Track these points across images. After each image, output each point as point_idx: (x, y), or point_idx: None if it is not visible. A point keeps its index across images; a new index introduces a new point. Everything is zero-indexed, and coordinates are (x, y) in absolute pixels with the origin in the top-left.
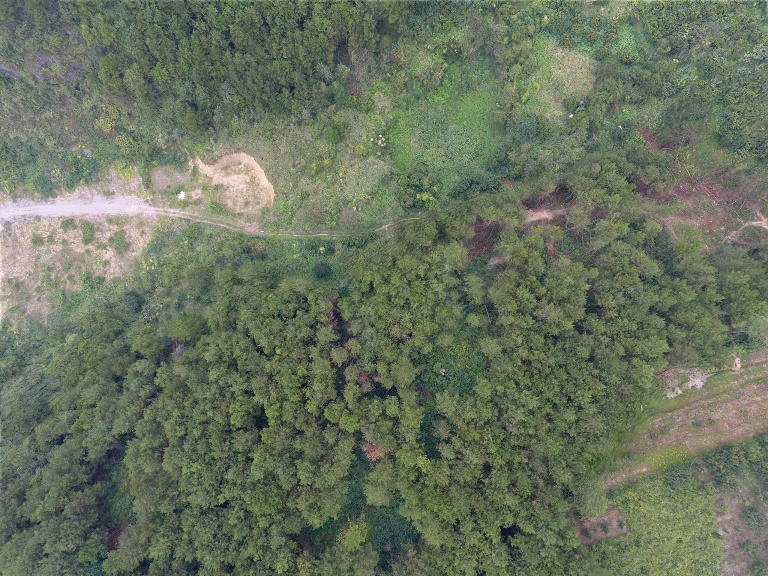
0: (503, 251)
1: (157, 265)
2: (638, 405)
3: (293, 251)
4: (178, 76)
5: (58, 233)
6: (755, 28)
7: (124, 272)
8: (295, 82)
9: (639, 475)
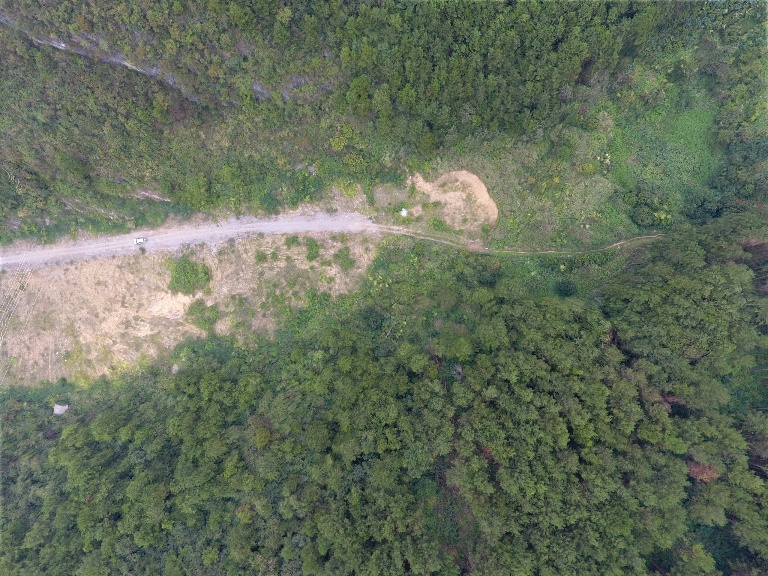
0: None
1: (390, 282)
2: None
3: (528, 269)
4: (425, 97)
5: (282, 250)
6: None
7: (350, 288)
8: (539, 103)
9: None
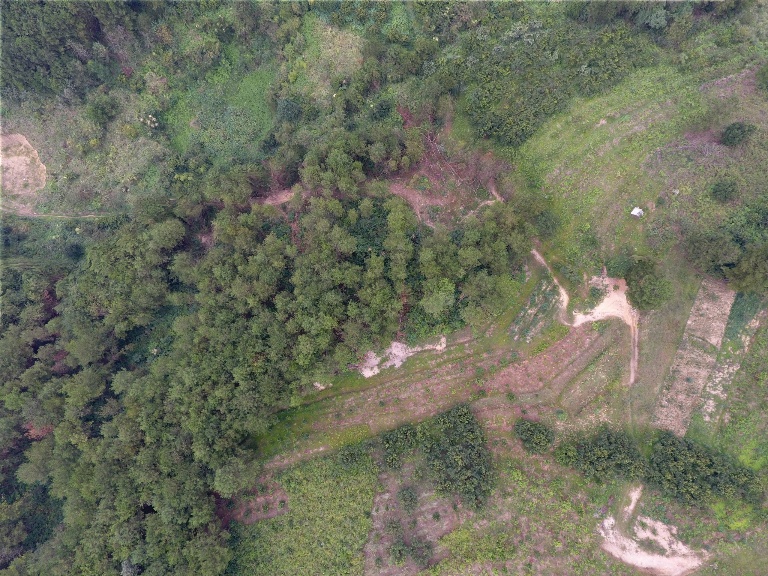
0: (212, 229)
1: None
2: (307, 383)
3: (54, 232)
4: None
5: None
6: (520, 6)
7: None
8: (47, 60)
9: (313, 454)
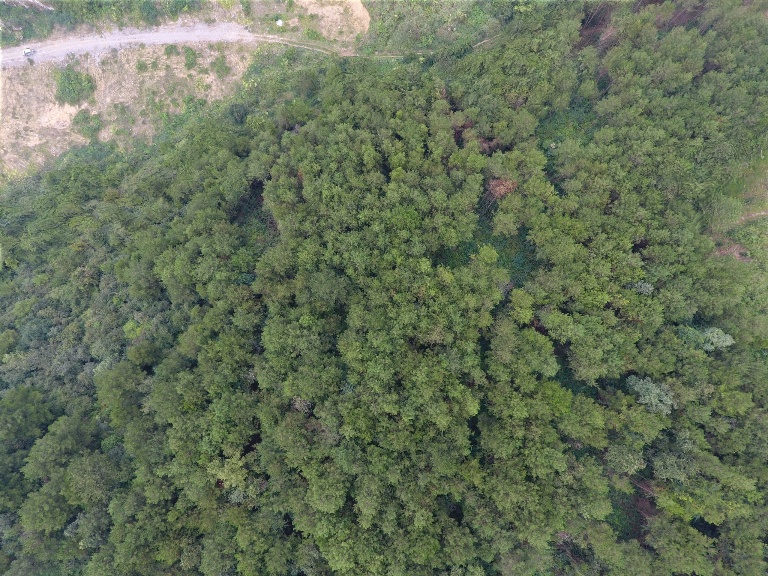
0: (615, 24)
1: None
2: (760, 144)
3: (391, 66)
4: None
5: (162, 59)
6: None
7: (225, 95)
8: None
9: (758, 216)
